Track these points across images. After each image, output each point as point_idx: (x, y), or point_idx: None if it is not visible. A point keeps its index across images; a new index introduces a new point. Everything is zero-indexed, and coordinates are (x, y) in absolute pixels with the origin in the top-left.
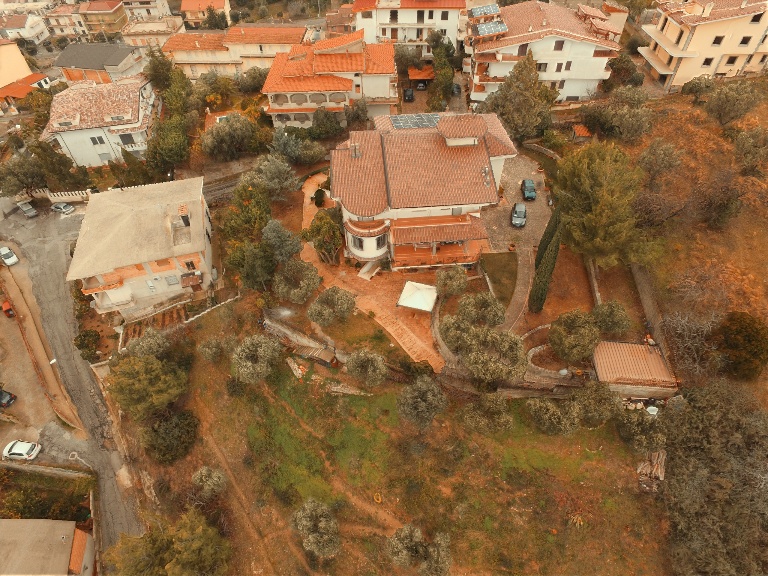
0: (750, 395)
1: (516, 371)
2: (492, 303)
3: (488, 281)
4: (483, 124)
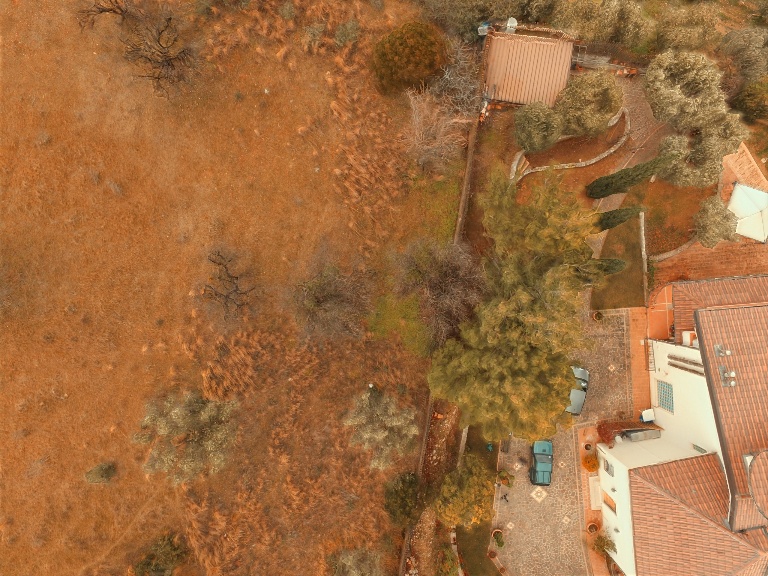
0: (428, 2)
1: (668, 57)
2: (680, 164)
3: (644, 247)
4: (762, 491)
